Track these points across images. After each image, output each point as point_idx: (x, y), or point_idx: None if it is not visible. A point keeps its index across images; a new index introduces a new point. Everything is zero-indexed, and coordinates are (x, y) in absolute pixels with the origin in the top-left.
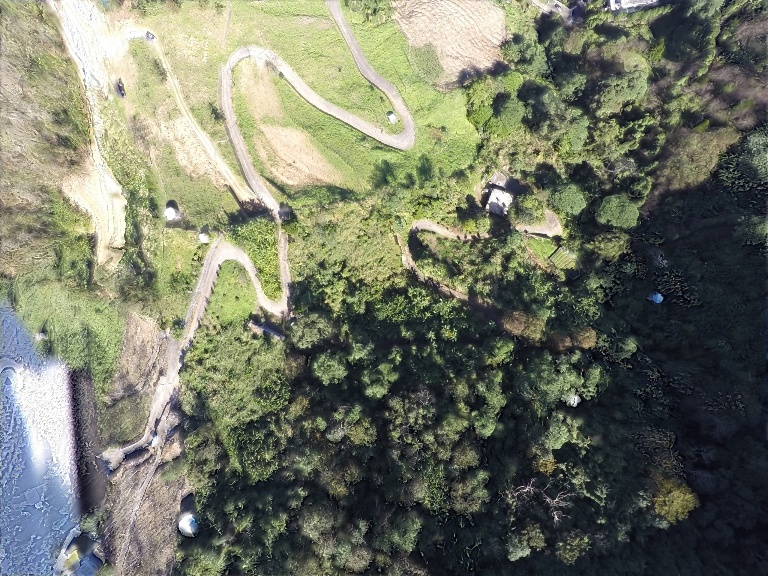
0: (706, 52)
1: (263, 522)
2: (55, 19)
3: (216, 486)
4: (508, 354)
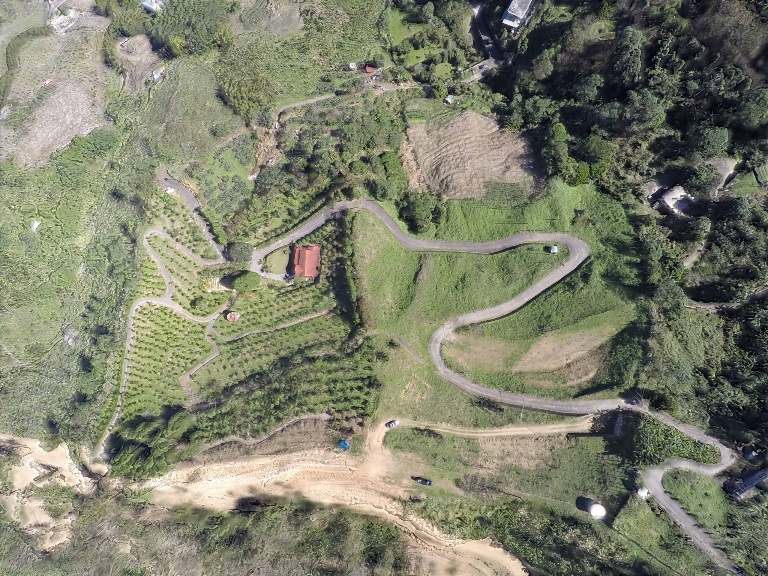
0: None
1: None
2: (313, 505)
3: None
4: None
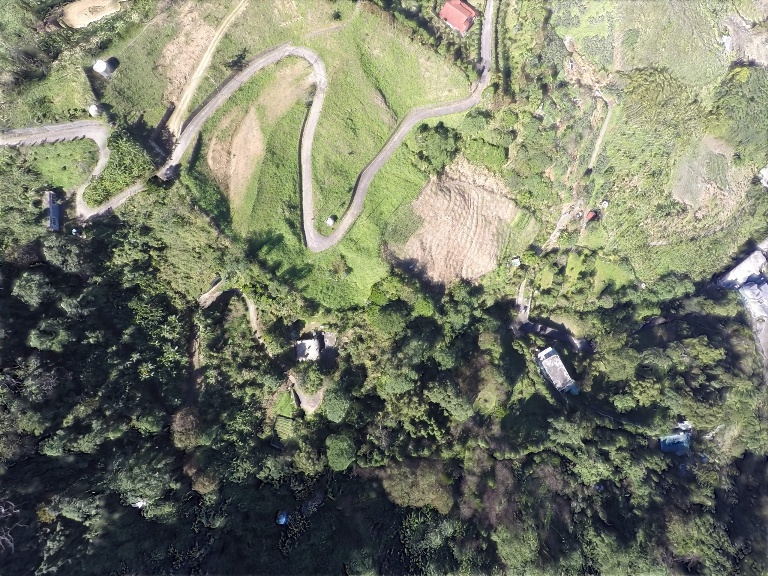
0: (515, 451)
1: None
2: None
3: None
4: (147, 430)
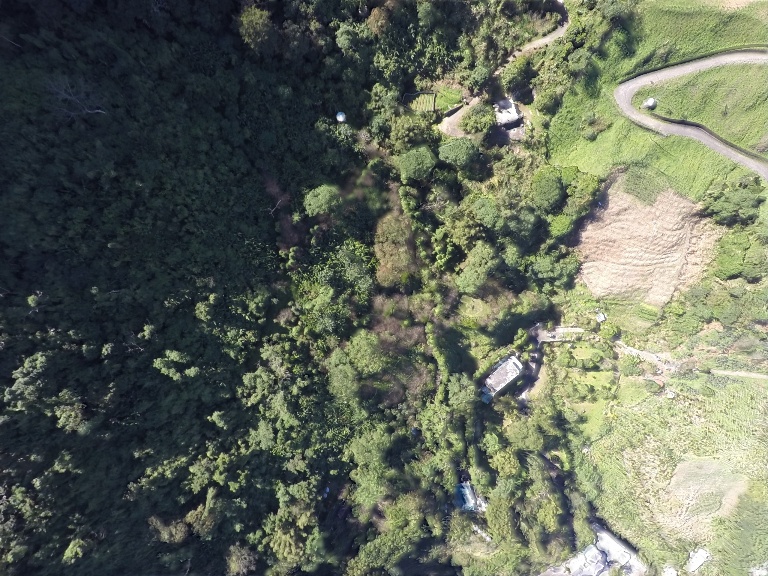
0: None
1: None
2: None
3: None
4: None
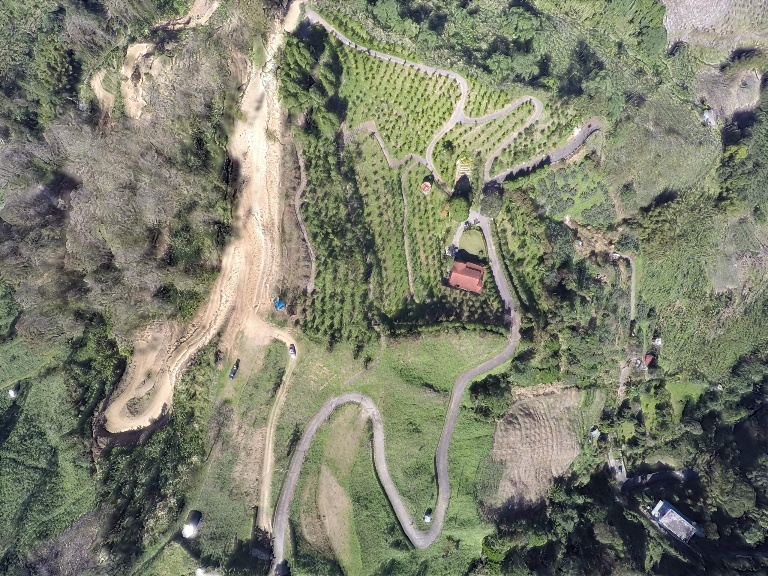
0: None
1: None
2: (226, 255)
3: None
4: None
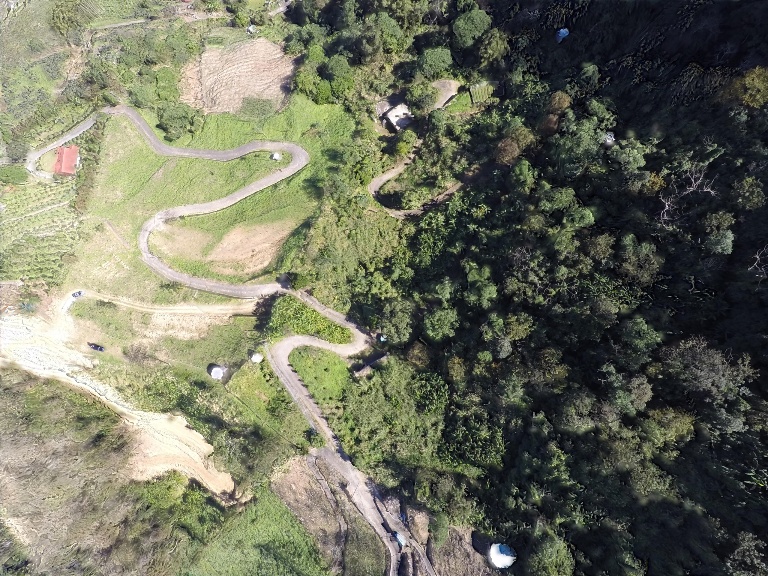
0: None
1: (544, 474)
2: (8, 365)
3: (480, 501)
4: (531, 169)
